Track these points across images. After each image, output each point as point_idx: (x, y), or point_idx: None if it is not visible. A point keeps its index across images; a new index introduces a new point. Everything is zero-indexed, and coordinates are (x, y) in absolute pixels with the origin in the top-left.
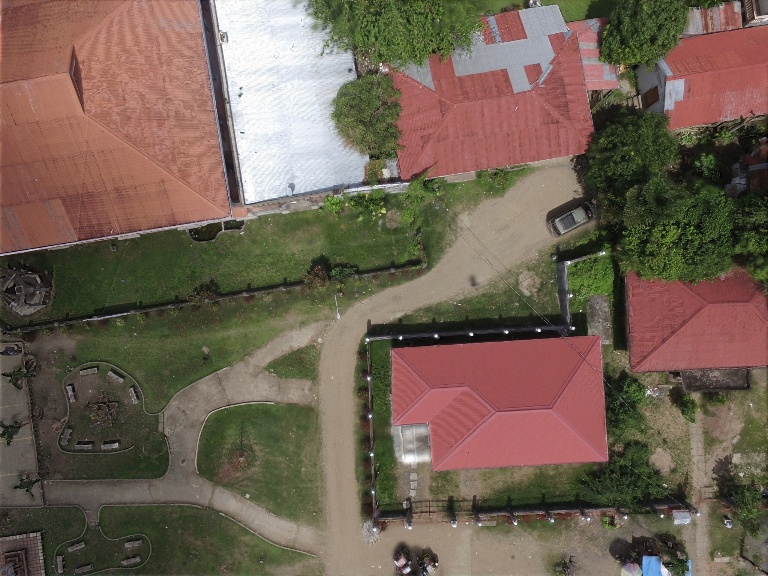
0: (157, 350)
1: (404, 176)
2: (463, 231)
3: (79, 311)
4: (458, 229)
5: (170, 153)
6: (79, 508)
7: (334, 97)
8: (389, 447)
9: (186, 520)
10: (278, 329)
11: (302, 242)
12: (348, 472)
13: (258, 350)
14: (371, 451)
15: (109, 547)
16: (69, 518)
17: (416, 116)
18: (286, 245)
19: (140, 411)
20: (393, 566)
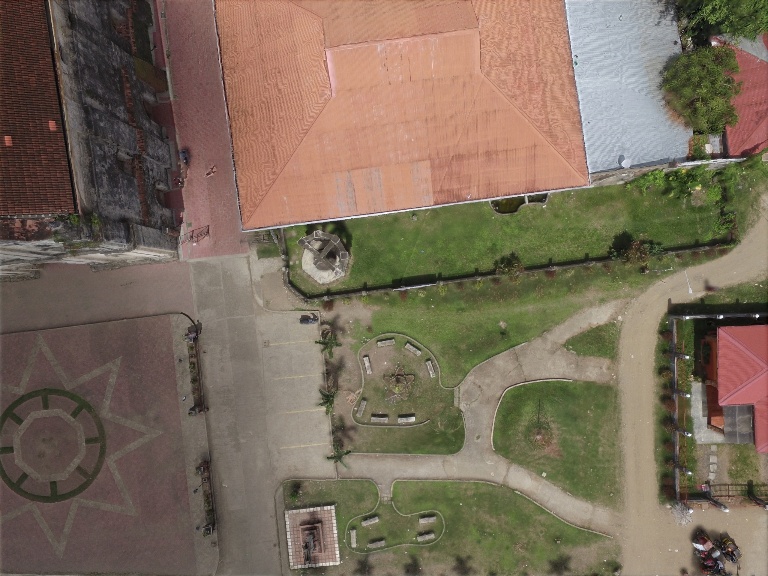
0: (454, 323)
1: (734, 152)
2: (766, 211)
3: (377, 281)
4: (760, 209)
5: (544, 117)
6: (372, 482)
7: (661, 69)
8: (689, 429)
9: (481, 497)
10: (577, 305)
11: (605, 217)
12: (647, 453)
13: (556, 326)
14: (686, 431)
15: (401, 523)
16: (361, 492)
17: (752, 90)
18: (588, 220)
19: (435, 385)
20: (690, 550)
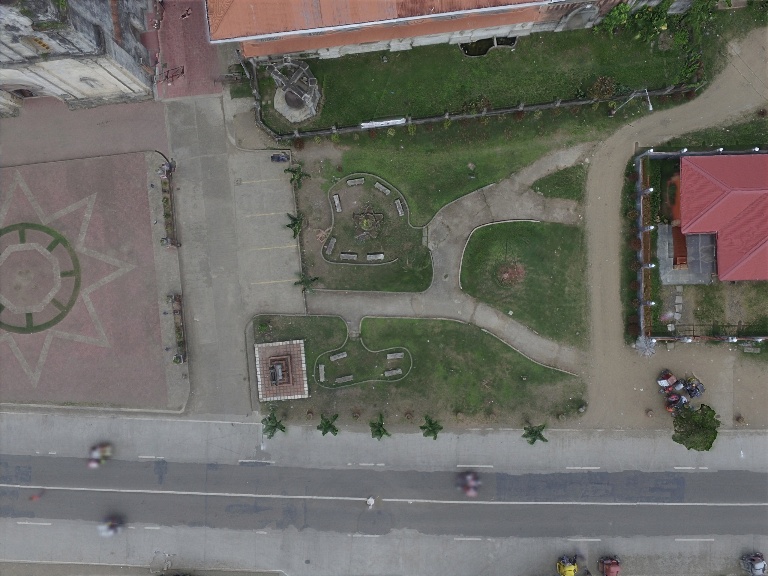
0: (423, 164)
1: None
2: (733, 58)
3: (348, 121)
4: (728, 56)
5: None
6: (341, 318)
7: None
8: (655, 269)
9: (448, 335)
10: (545, 148)
11: (573, 61)
12: (613, 293)
13: (524, 168)
14: None
15: (369, 359)
16: (330, 328)
17: None
18: (557, 64)
19: (404, 224)
20: (655, 389)
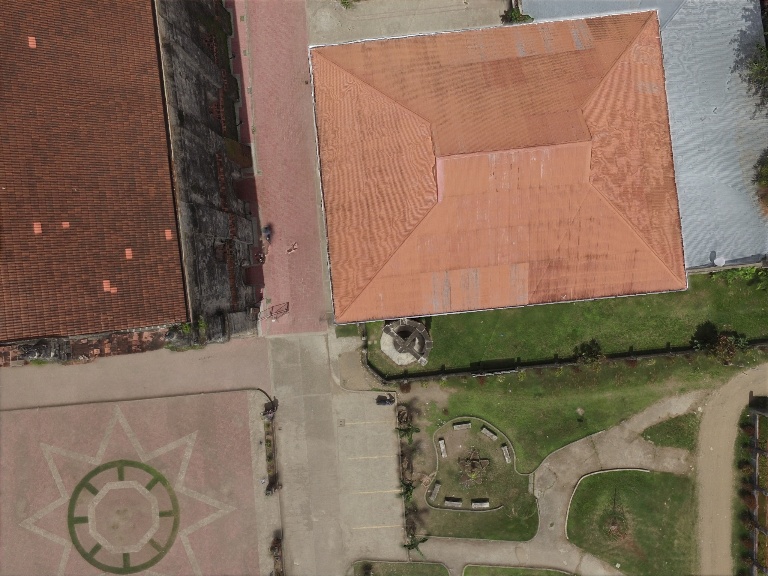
0: (531, 408)
1: None
2: None
3: (455, 364)
4: None
5: (647, 223)
6: (444, 566)
7: (754, 163)
8: (767, 525)
9: None
10: (657, 395)
11: (688, 307)
12: (724, 548)
13: (635, 415)
14: None
15: None
16: (433, 575)
17: None
18: (671, 309)
19: (510, 470)
20: None
